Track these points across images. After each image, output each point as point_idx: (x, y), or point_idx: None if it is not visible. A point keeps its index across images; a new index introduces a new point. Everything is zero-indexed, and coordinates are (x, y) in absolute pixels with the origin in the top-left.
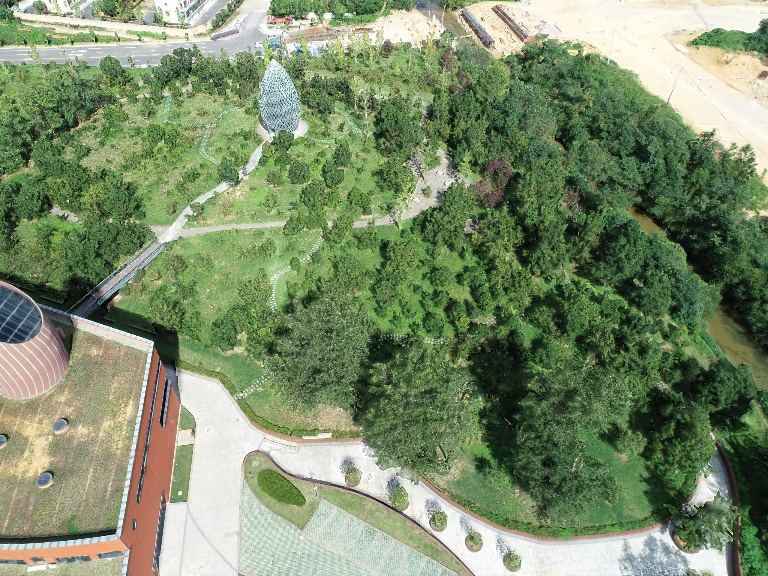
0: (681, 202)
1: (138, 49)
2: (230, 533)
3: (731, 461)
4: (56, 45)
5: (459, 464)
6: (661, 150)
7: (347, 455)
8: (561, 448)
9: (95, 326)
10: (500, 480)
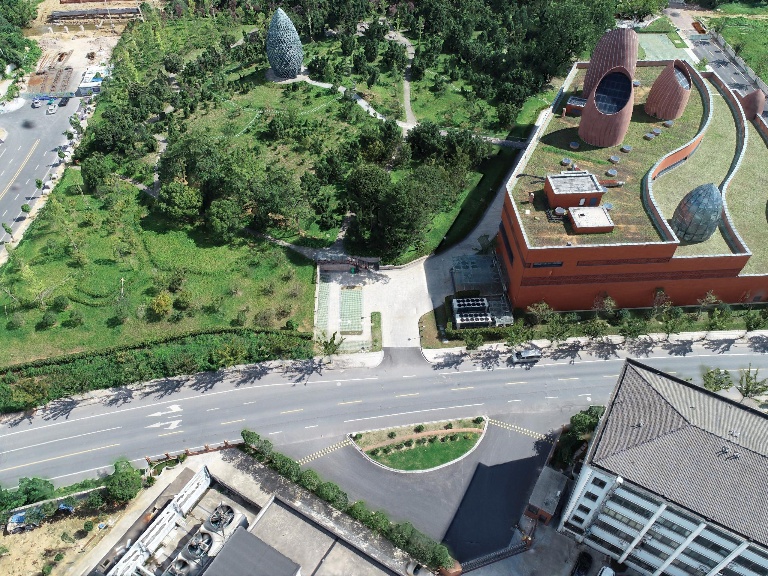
0: None
1: None
2: None
3: None
4: None
5: None
6: None
7: None
8: None
9: None
10: None
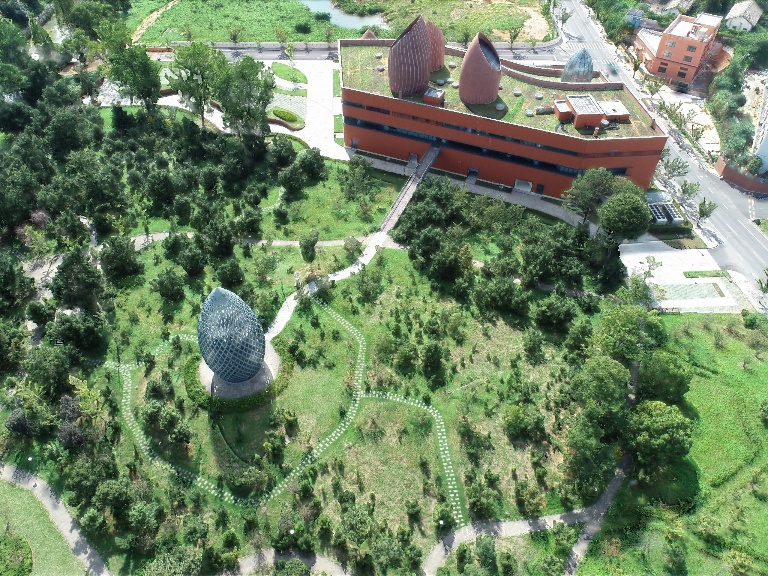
0: None
1: None
2: None
3: None
4: None
5: None
6: None
7: None
8: None
9: None
10: None
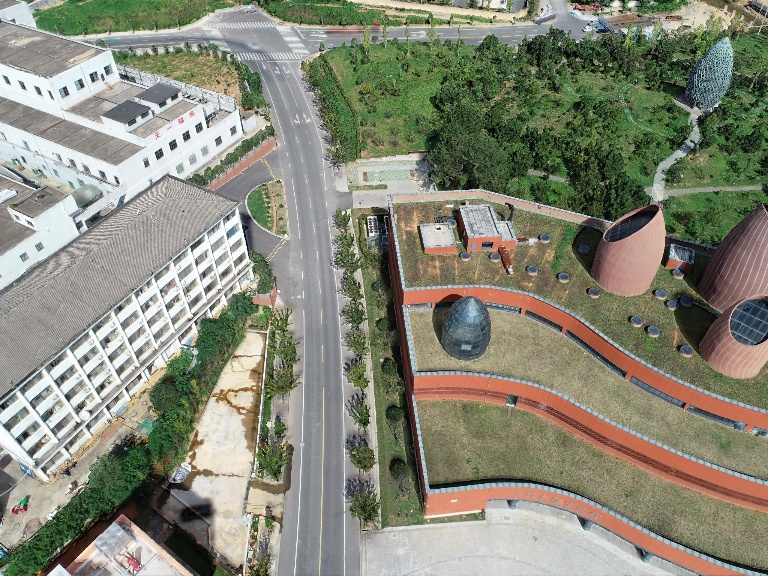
0: None
1: (473, 31)
2: None
3: None
4: (393, 26)
5: None
6: None
7: None
8: None
9: None
10: None
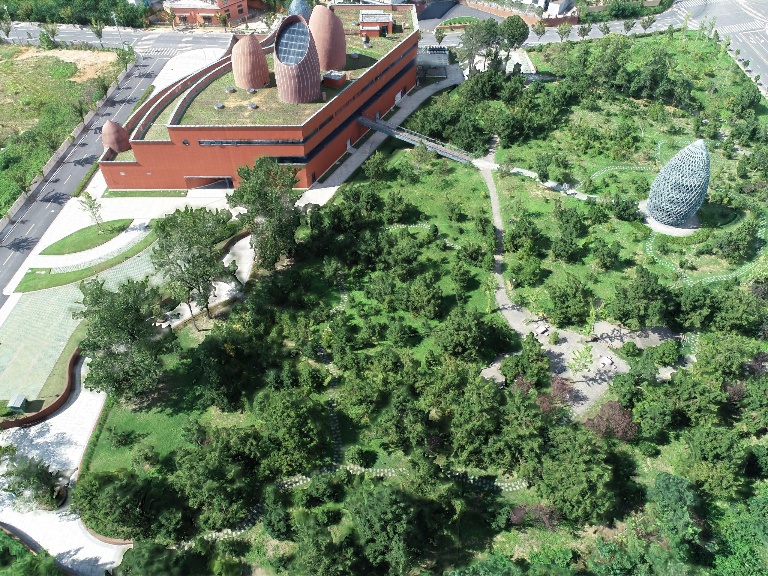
0: None
1: None
2: None
3: None
4: None
5: (201, 337)
6: None
7: (239, 273)
8: None
9: None
10: None
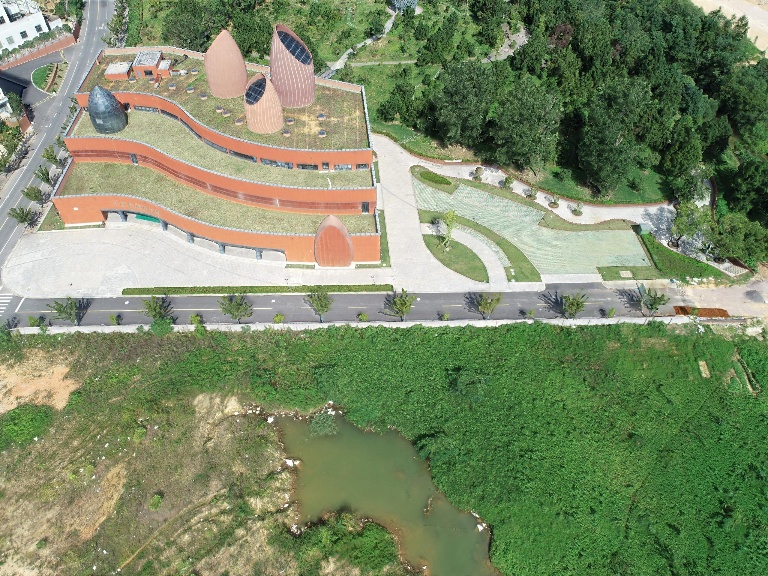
0: (694, 57)
1: None
2: (409, 194)
3: (714, 177)
4: None
5: (543, 175)
6: (681, 23)
7: (472, 170)
8: (610, 126)
9: (326, 80)
10: (569, 176)
